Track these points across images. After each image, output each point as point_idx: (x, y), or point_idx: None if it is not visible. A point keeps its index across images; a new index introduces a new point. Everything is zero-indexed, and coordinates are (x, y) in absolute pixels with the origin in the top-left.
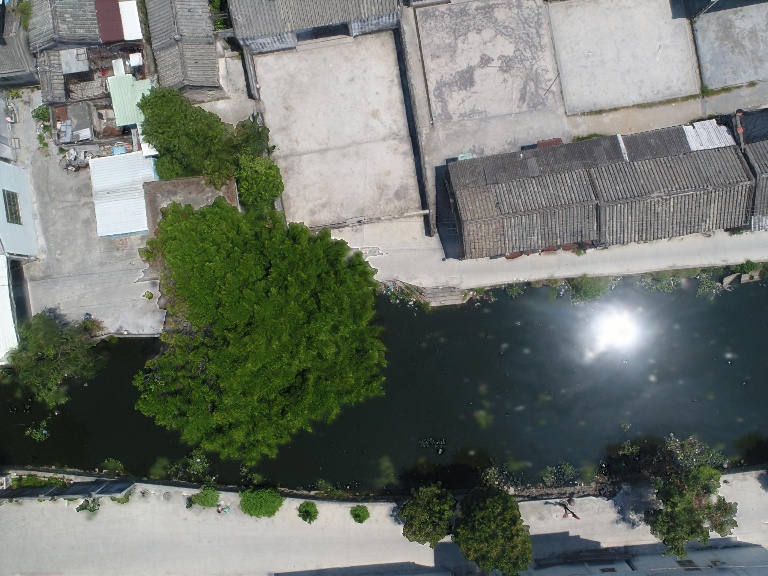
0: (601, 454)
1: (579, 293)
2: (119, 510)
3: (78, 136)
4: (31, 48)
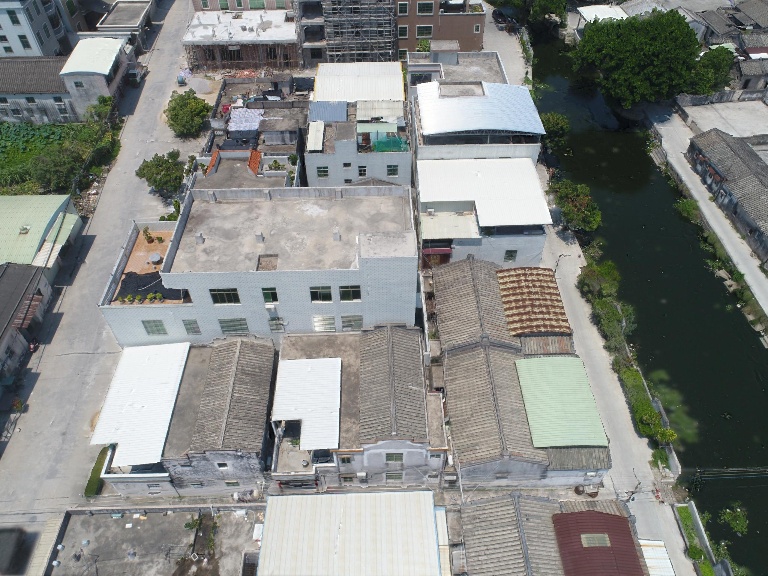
0: None
1: None
2: (518, 62)
3: None
4: None
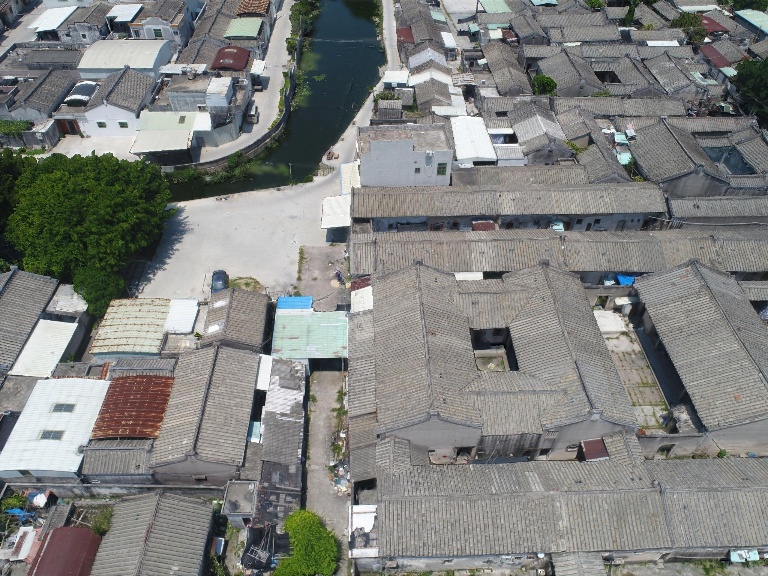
0: (318, 1)
1: None
2: None
3: None
4: None
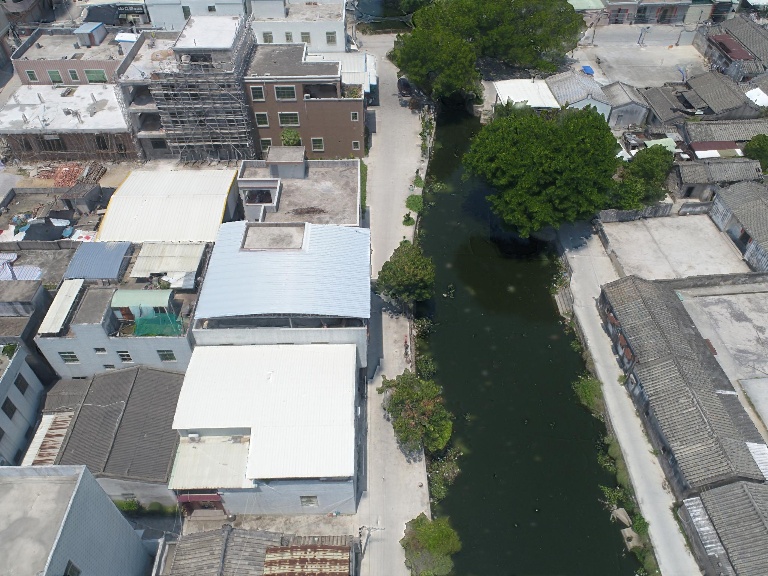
0: (443, 397)
1: (584, 382)
2: (413, 153)
3: (631, 140)
4: None
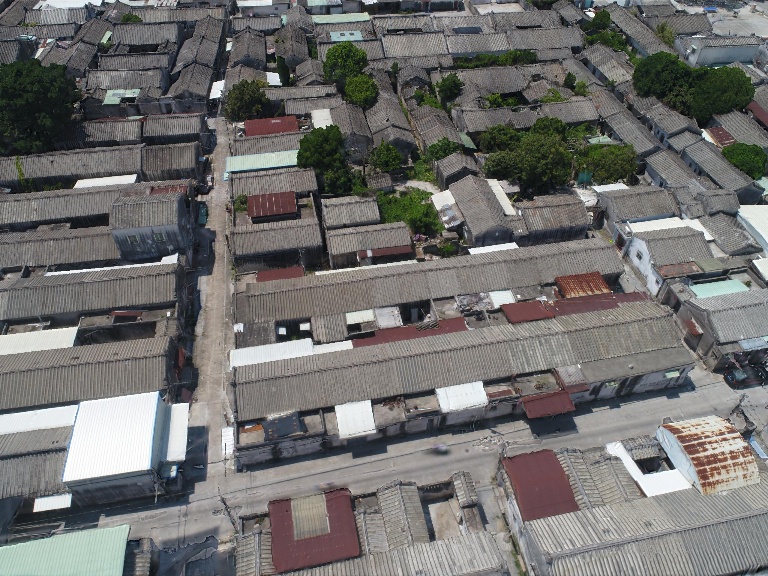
0: None
1: None
2: None
3: None
4: (626, 8)
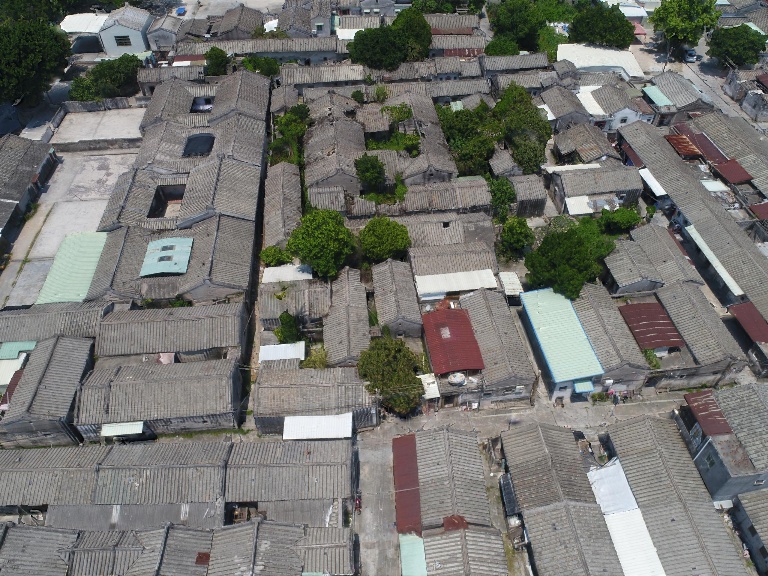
0: None
1: None
2: None
3: None
4: None
